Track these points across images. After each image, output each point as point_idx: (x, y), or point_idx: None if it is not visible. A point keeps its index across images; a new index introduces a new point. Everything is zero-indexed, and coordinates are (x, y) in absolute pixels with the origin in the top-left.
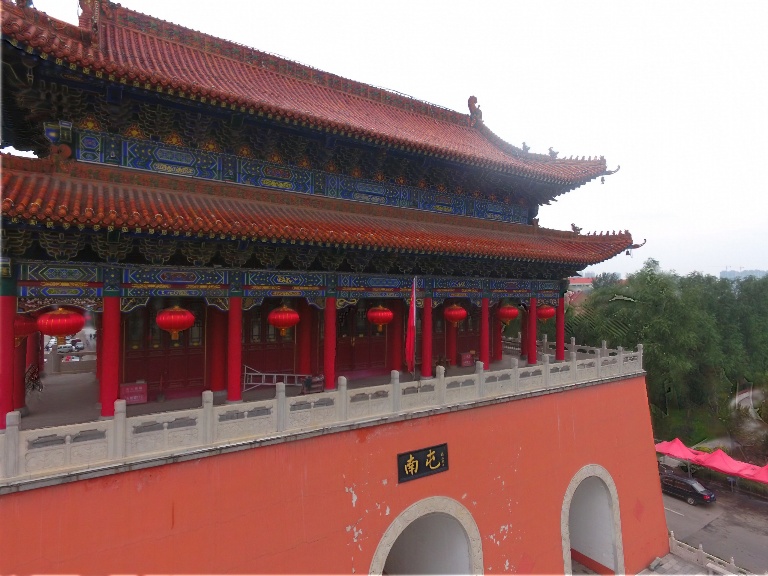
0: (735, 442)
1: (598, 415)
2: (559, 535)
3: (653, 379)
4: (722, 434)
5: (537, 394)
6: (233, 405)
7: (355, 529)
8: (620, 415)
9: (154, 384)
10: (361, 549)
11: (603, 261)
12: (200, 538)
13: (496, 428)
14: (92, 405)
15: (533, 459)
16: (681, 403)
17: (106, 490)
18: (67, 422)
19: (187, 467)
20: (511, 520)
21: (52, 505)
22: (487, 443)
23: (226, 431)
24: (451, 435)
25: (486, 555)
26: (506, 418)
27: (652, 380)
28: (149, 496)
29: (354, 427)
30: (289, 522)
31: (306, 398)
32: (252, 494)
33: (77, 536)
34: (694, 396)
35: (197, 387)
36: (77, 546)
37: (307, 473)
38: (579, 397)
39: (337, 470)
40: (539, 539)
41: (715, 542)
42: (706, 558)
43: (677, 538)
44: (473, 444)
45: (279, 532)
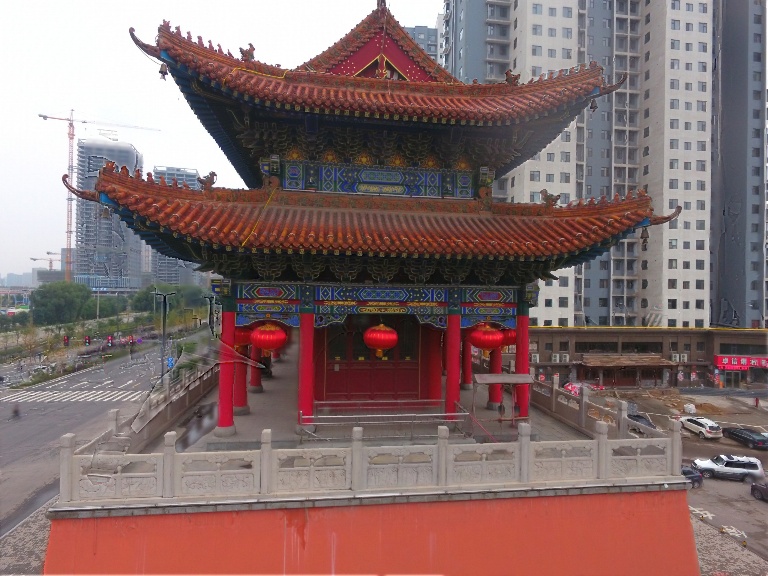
0: None
1: None
2: None
3: None
4: None
5: None
6: None
7: None
8: None
9: None
10: None
11: (147, 243)
12: None
13: None
14: None
15: None
16: None
17: None
18: None
19: None
20: None
21: None
22: None
23: None
24: None
25: None
26: None
27: None
28: None
29: None
30: None
31: None
32: None
33: None
34: None
35: None
36: None
37: None
38: None
39: None
40: None
41: None
42: None
43: None
44: None
45: None
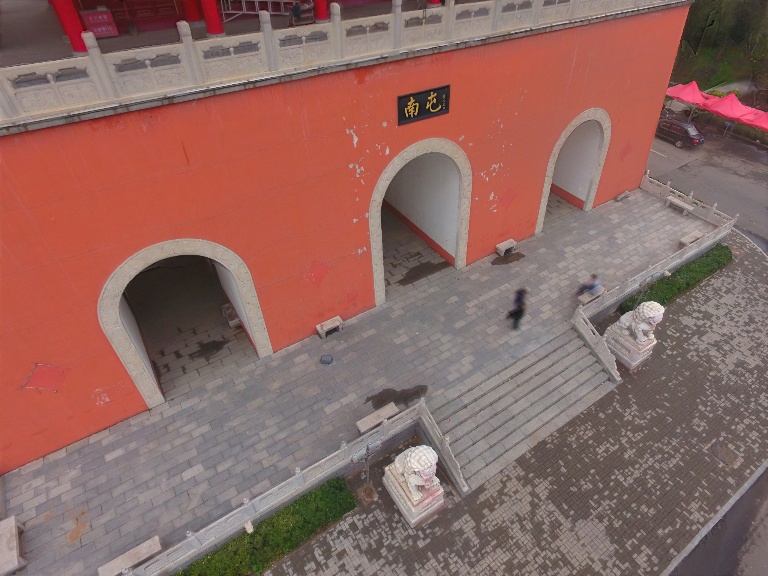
0: (753, 86)
1: (619, 54)
2: (544, 173)
3: (699, 9)
4: (744, 77)
5: (558, 28)
6: (215, 39)
7: (357, 166)
8: (643, 54)
9: (119, 12)
10: (363, 183)
11: None
12: (216, 173)
13: (504, 68)
14: (59, 38)
15: (536, 102)
16: (718, 40)
17: (113, 130)
18: (41, 59)
19: (185, 108)
20: (503, 160)
21: (67, 144)
22: (492, 85)
23: (215, 70)
24: (455, 76)
25: (475, 188)
26: (517, 57)
27: (698, 10)
28: (157, 136)
29: (351, 66)
30: (295, 160)
31: (295, 31)
32: (256, 135)
33: (104, 171)
34: (736, 31)
35: (169, 16)
36: (108, 179)
37: (307, 115)
38: (605, 32)
39: (337, 112)
40: (525, 176)
41: (684, 179)
42: (669, 192)
43: (651, 176)
44: (477, 86)
45: (288, 169)
